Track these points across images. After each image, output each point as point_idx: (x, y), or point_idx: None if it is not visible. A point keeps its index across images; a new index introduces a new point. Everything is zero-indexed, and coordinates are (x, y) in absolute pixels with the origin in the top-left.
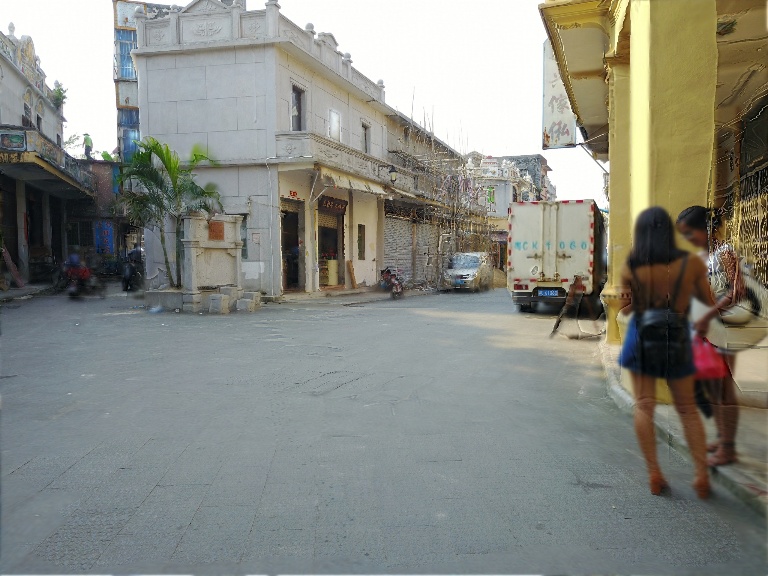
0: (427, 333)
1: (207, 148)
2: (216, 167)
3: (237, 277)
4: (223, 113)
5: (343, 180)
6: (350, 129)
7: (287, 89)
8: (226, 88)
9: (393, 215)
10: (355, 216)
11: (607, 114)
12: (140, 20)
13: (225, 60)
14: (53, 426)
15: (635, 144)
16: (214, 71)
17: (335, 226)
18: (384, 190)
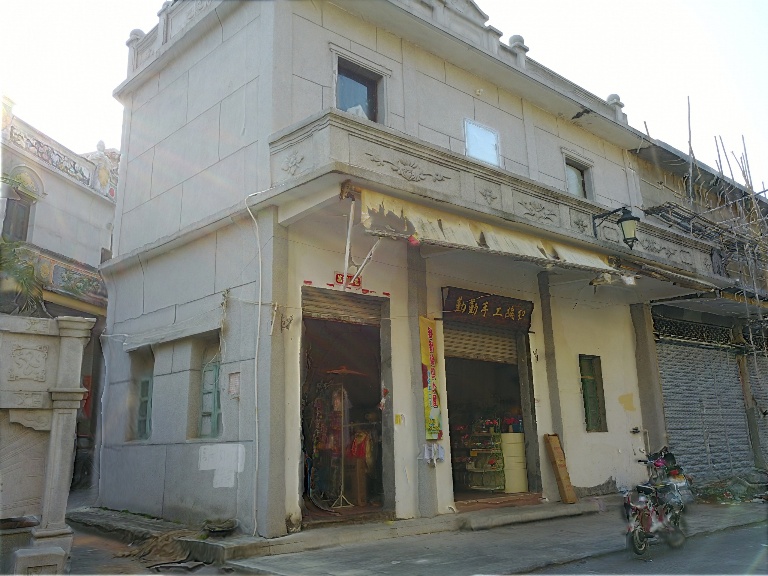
0: None
1: (180, 211)
2: (189, 243)
3: (44, 495)
4: (203, 138)
5: (453, 228)
6: (531, 163)
7: (319, 62)
8: (209, 92)
9: (680, 338)
10: (568, 337)
11: None
12: (132, 46)
13: (210, 45)
14: None
15: None
16: (197, 72)
17: (510, 358)
18: (618, 269)
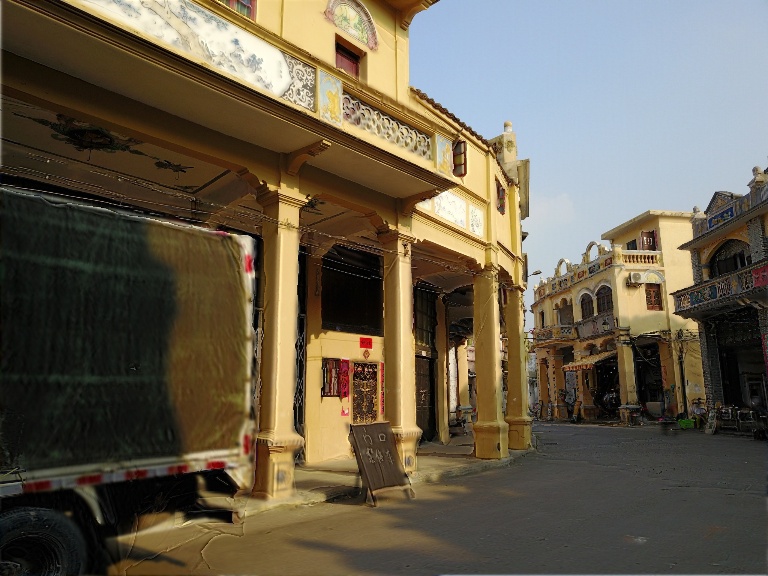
0: (566, 507)
1: None
2: None
3: None
4: None
5: None
6: None
7: None
8: None
9: None
10: None
11: (28, 46)
12: None
13: None
14: (753, 460)
15: (496, 352)
16: None
17: None
18: None
